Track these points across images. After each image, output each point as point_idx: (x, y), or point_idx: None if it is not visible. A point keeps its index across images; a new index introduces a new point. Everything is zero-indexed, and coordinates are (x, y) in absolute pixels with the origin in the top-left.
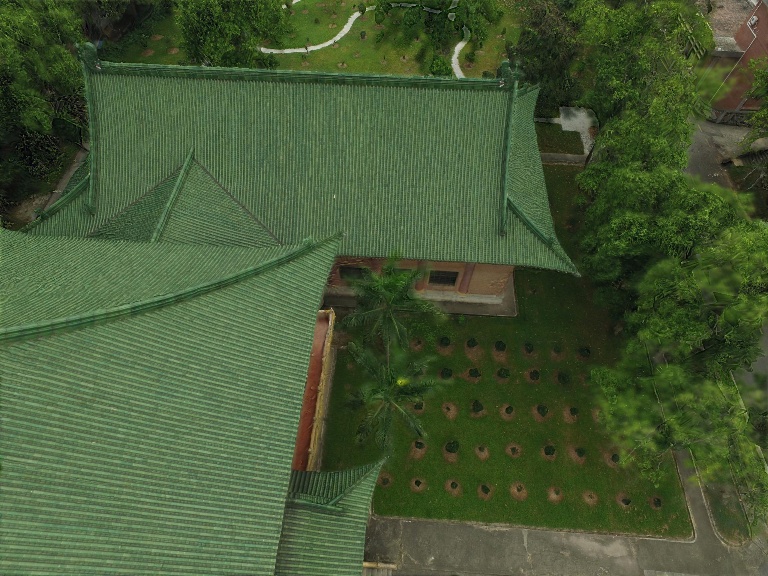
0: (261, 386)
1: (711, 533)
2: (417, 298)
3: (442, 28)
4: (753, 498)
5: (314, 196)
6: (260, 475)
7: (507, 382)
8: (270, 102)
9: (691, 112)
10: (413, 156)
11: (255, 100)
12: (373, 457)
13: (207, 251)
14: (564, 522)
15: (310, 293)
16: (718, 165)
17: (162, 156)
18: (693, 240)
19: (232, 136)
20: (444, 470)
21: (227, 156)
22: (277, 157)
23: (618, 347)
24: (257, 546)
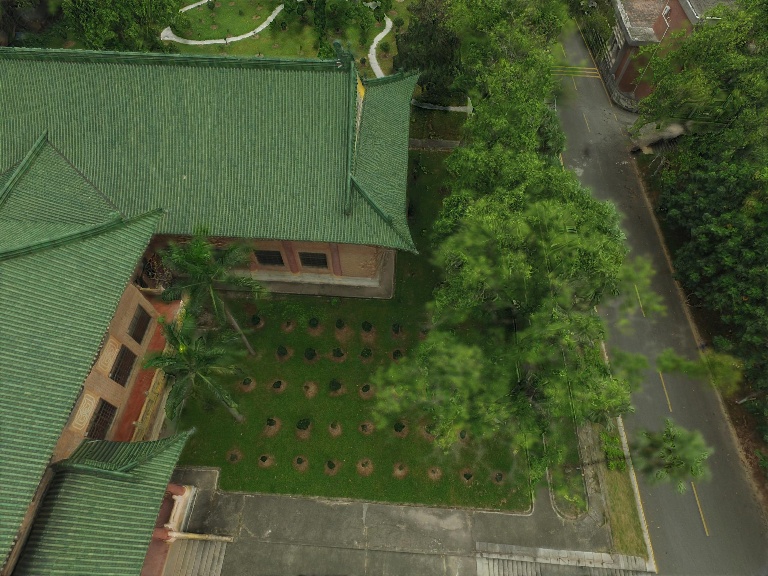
0: (42, 353)
1: (549, 506)
2: (296, 281)
3: (322, 14)
4: (530, 463)
5: (165, 177)
6: (23, 438)
7: (371, 362)
8: (118, 84)
9: (609, 102)
10: (261, 137)
11: (104, 82)
12: (226, 434)
13: (30, 227)
14: (405, 496)
15: (120, 266)
16: (628, 153)
17: (17, 138)
18: (507, 215)
19: (84, 118)
20: (294, 447)
21: (80, 138)
22: (128, 138)
23: (487, 328)
24: (3, 504)
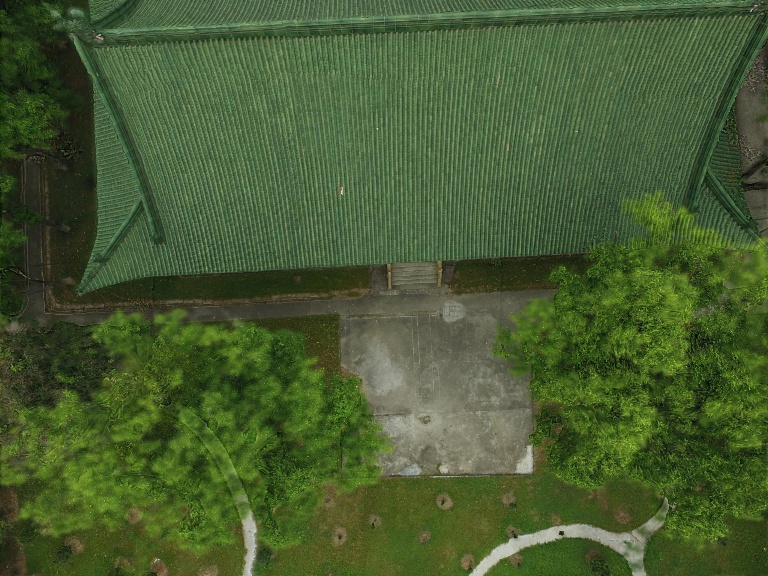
0: None
1: None
2: None
3: None
4: None
5: None
6: None
7: None
8: None
9: None
10: None
11: None
12: None
13: None
14: None
15: None
16: None
17: None
18: None
19: (514, 3)
20: None
21: None
22: None
23: None
24: None
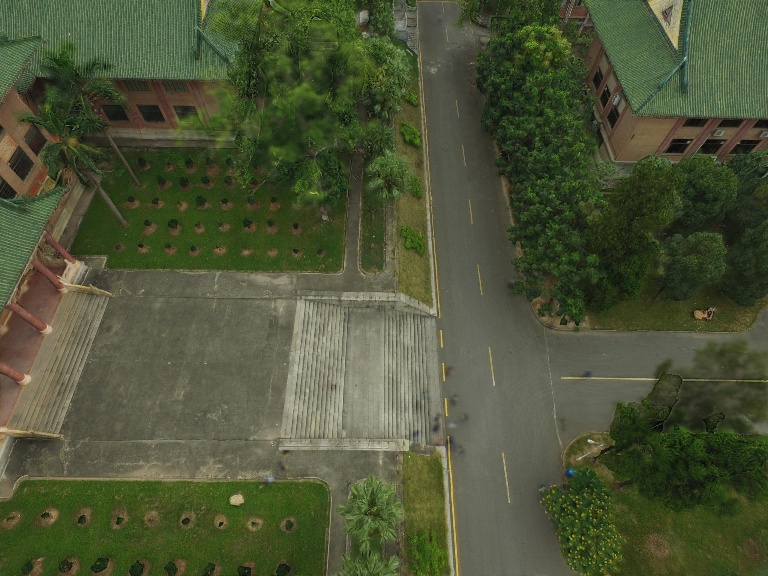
0: None
1: (355, 268)
2: (179, 138)
3: None
4: None
5: (54, 34)
6: None
7: (233, 188)
8: None
9: (469, 20)
10: (128, 1)
11: None
12: (113, 235)
13: None
14: (248, 266)
15: (7, 72)
16: None
17: None
18: None
19: None
20: (167, 240)
21: None
22: (23, 5)
23: None
24: None
